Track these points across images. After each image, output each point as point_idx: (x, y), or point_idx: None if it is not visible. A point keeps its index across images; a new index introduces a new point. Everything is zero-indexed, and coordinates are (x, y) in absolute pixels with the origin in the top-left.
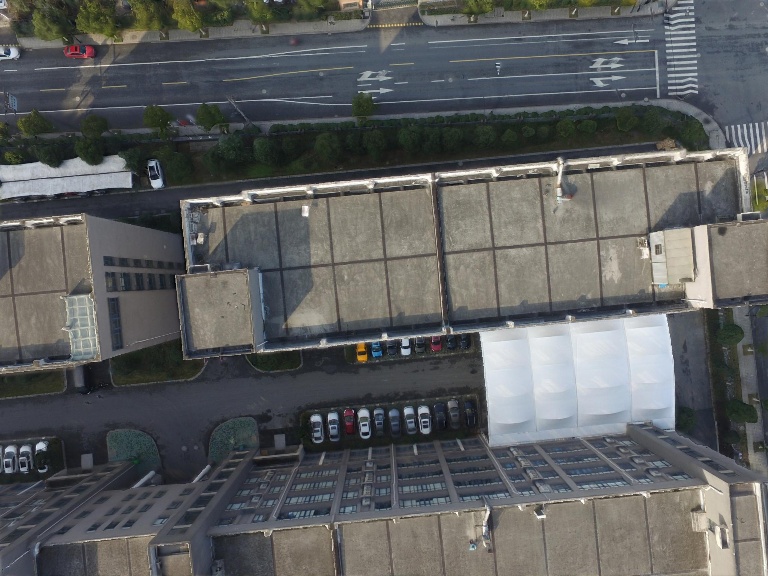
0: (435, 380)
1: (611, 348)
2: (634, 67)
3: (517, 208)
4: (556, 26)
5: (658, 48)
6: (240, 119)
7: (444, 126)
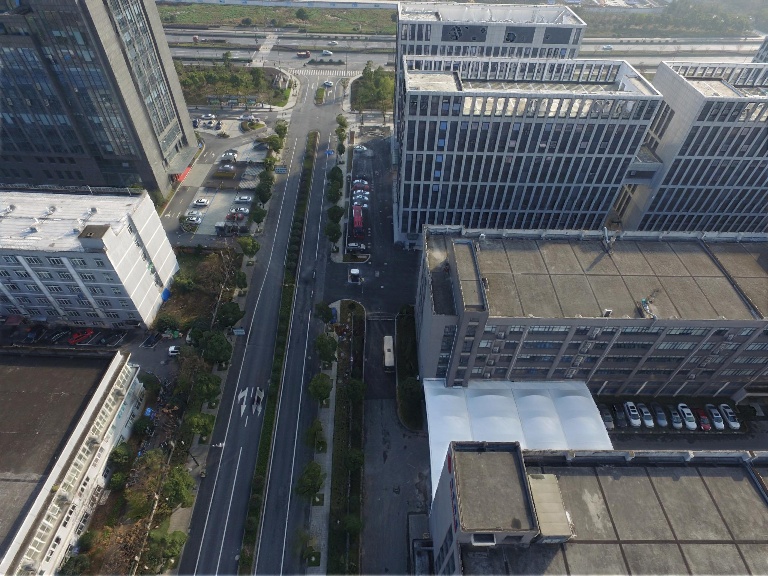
0: None
1: None
2: None
3: None
4: None
5: None
6: None
7: None
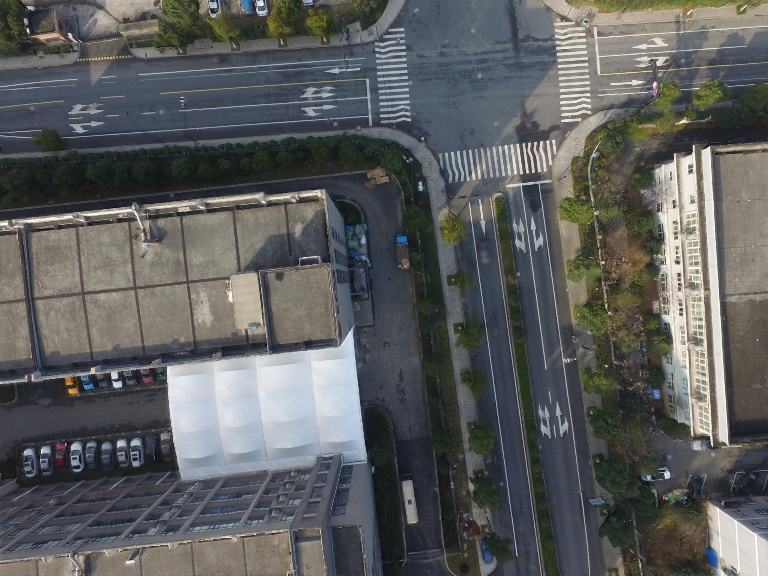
0: (150, 412)
1: (293, 381)
2: (345, 96)
3: (106, 252)
4: (266, 56)
5: (369, 76)
6: None
7: (149, 159)
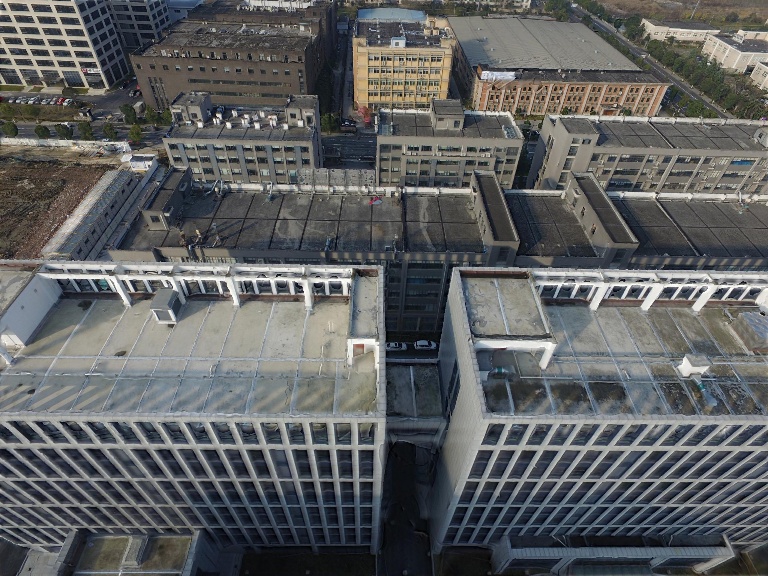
0: None
1: None
2: None
3: None
4: None
5: None
6: None
7: None
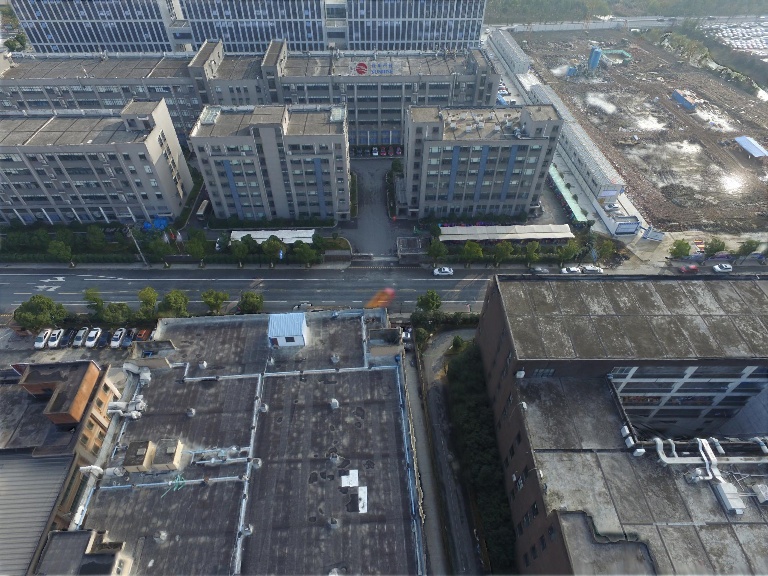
0: None
1: None
2: None
3: None
4: None
5: None
6: (155, 271)
7: None
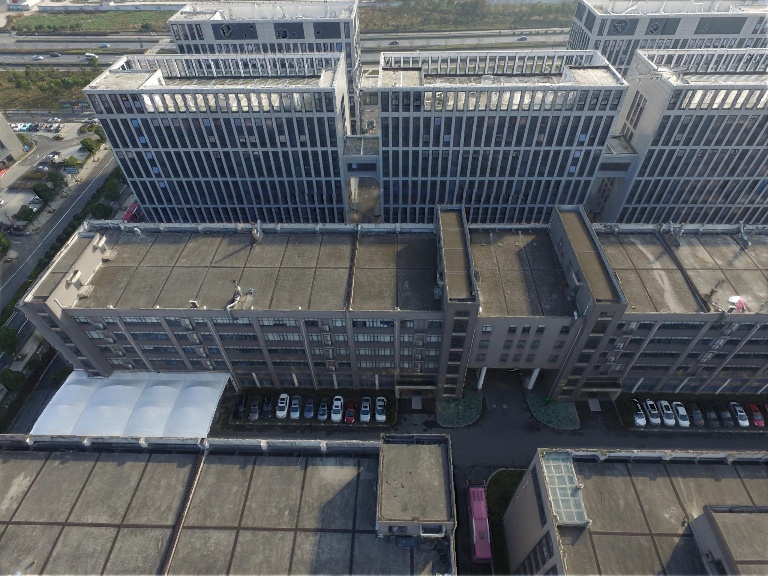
0: None
1: None
2: None
3: (70, 574)
4: None
5: None
6: None
7: None
